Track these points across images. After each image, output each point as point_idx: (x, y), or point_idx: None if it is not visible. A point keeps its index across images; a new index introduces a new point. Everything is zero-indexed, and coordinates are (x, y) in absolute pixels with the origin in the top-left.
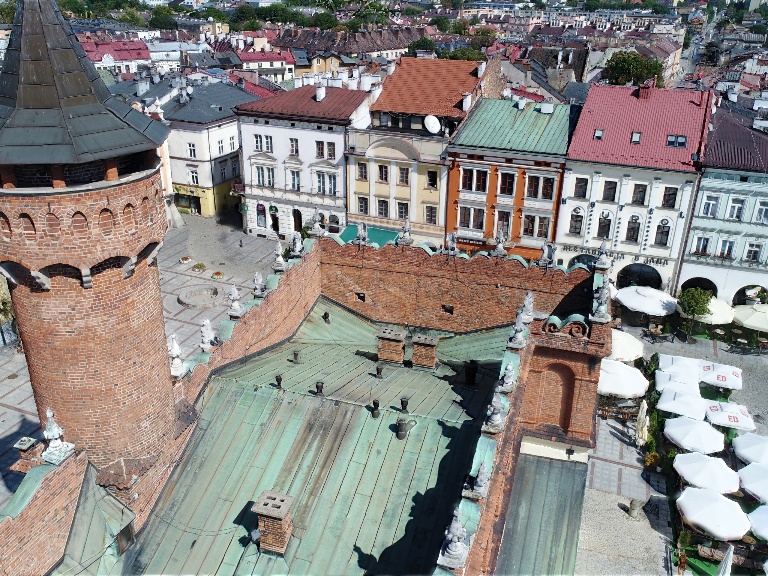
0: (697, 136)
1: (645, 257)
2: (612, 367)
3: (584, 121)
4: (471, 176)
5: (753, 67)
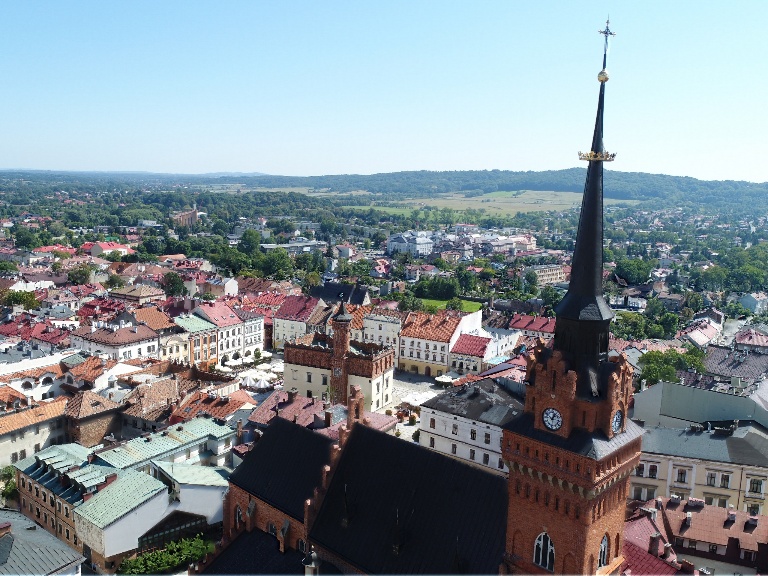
0: (234, 313)
1: (237, 350)
2: (281, 366)
3: (210, 317)
4: (196, 342)
5: (23, 285)
